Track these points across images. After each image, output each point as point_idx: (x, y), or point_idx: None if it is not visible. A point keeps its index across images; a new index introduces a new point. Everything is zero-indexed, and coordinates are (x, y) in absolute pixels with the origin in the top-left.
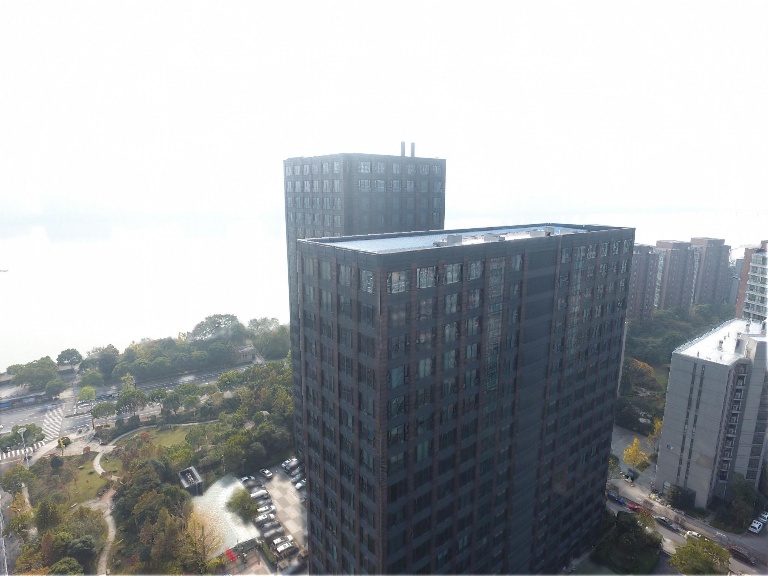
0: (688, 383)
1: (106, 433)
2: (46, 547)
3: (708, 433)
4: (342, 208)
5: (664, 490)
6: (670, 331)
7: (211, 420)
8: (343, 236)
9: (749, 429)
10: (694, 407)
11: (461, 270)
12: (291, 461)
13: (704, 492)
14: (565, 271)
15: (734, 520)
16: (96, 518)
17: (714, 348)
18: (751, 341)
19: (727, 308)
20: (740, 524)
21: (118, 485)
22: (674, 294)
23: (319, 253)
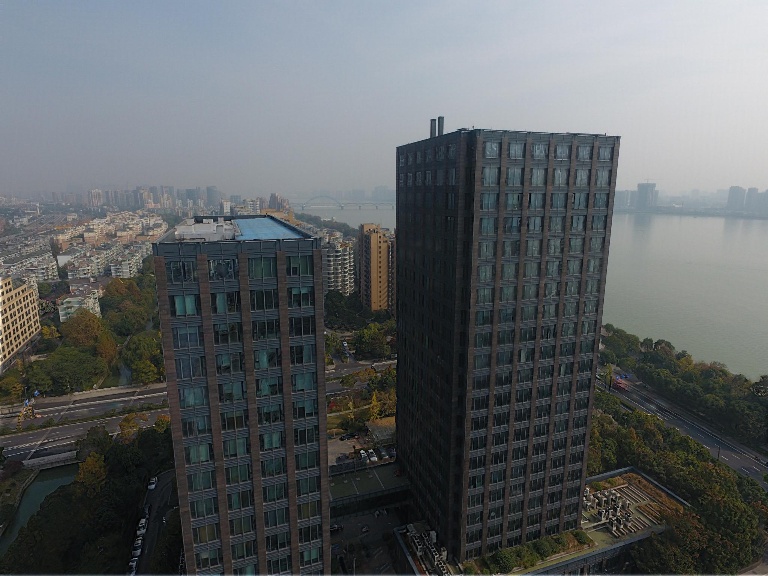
0: None
1: None
2: None
3: None
4: None
5: None
6: None
7: None
8: None
9: None
10: None
11: None
12: None
13: None
14: None
15: None
16: None
17: None
18: None
19: None
20: None
21: None
22: None
23: None
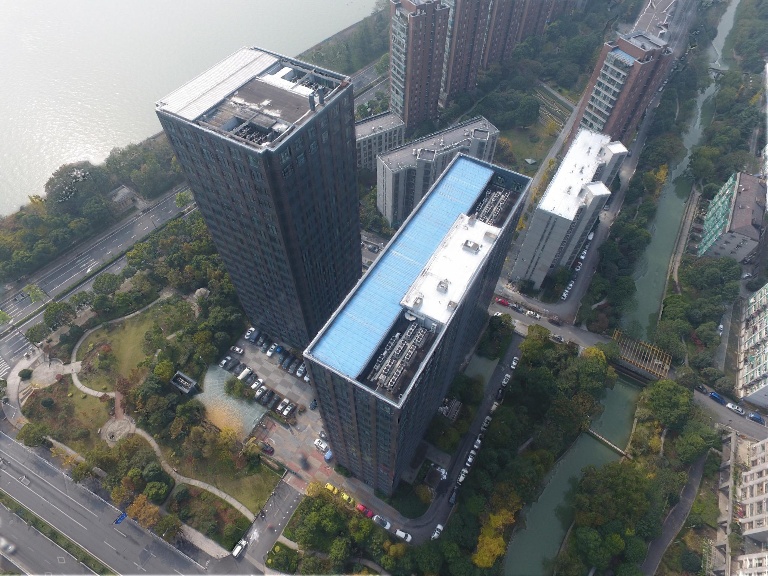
0: (543, 227)
1: (60, 353)
2: (128, 484)
3: (550, 255)
4: (270, 199)
5: (516, 280)
6: (525, 75)
7: (149, 304)
8: (329, 322)
9: (574, 243)
10: (544, 241)
11: (434, 353)
12: (251, 332)
13: (540, 283)
14: (486, 267)
15: (554, 294)
16: (139, 444)
17: (564, 191)
18: (590, 194)
19: (574, 25)
20: (557, 296)
21: (124, 405)
22: (532, 20)
23: (332, 374)
